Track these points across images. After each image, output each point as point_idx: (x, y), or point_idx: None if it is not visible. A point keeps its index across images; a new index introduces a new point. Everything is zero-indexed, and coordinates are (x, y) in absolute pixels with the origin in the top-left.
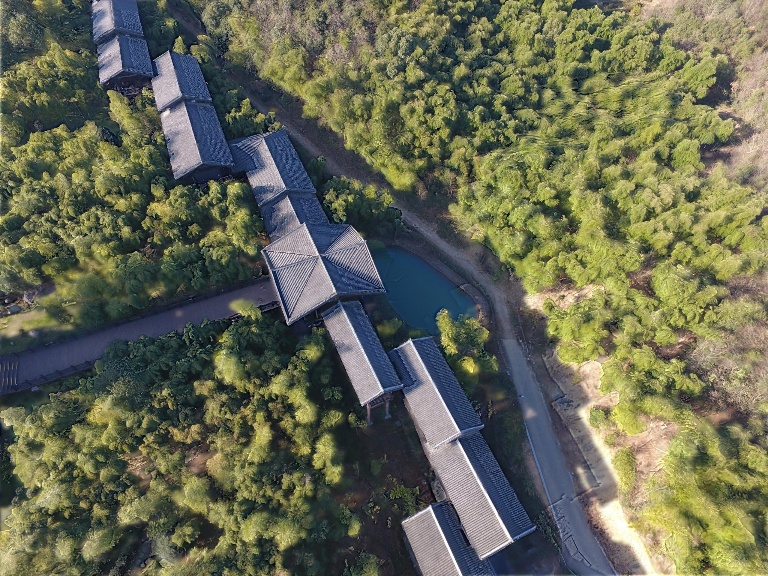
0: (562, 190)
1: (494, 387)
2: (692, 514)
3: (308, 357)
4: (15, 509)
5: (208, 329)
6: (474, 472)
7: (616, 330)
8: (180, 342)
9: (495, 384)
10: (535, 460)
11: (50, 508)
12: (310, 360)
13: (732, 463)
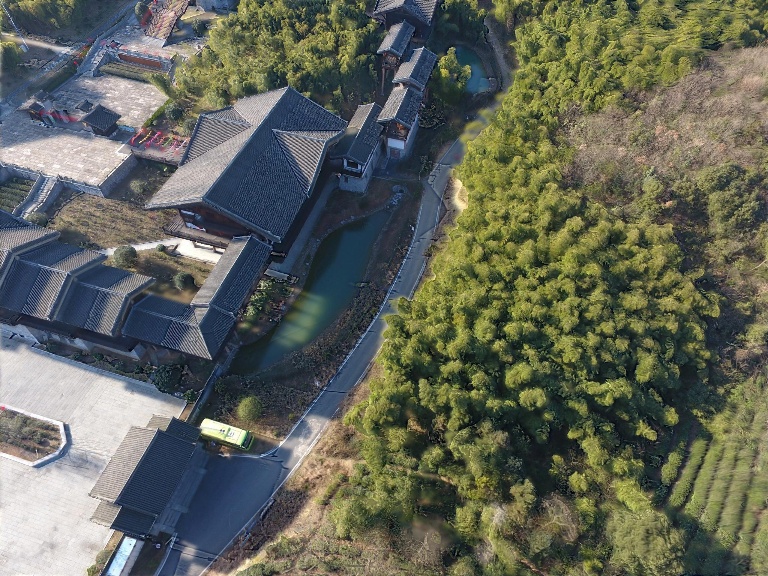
0: (586, 33)
1: (460, 117)
2: (485, 146)
3: (371, 30)
4: (231, 13)
5: (339, 6)
6: (403, 97)
7: (538, 91)
8: (324, 2)
9: (460, 111)
10: (449, 148)
11: (241, 20)
12: (371, 33)
13: (529, 142)
